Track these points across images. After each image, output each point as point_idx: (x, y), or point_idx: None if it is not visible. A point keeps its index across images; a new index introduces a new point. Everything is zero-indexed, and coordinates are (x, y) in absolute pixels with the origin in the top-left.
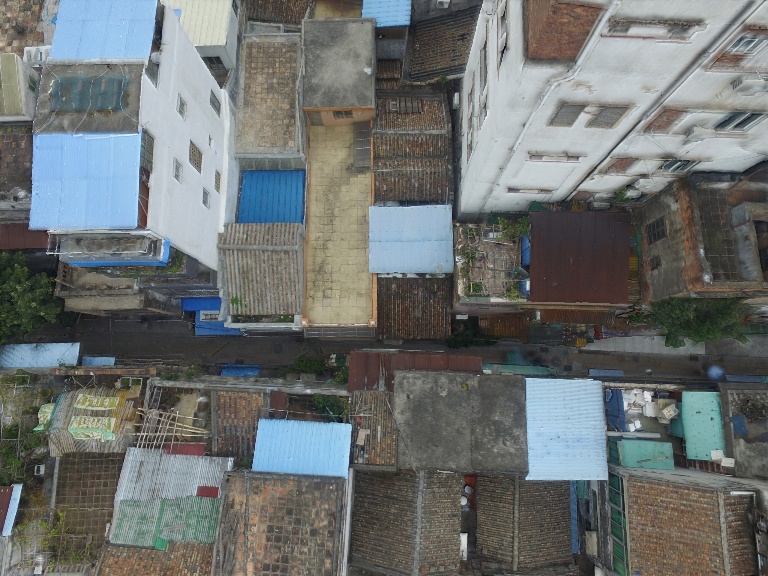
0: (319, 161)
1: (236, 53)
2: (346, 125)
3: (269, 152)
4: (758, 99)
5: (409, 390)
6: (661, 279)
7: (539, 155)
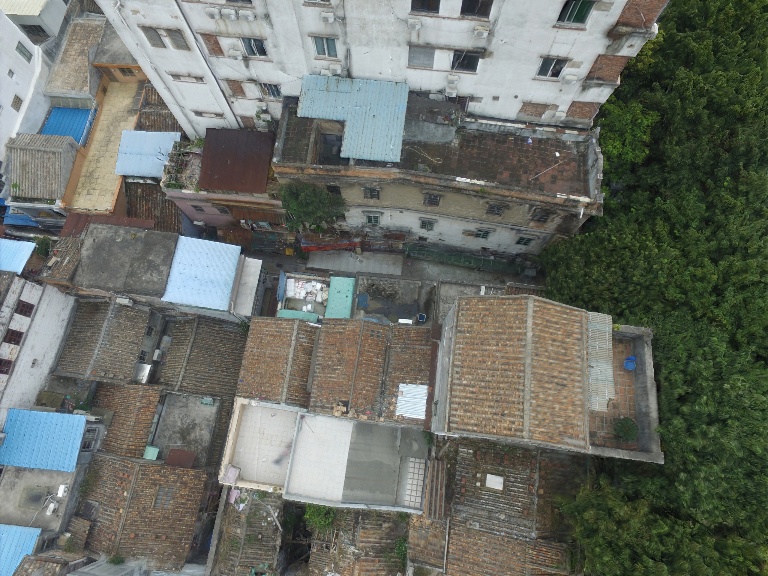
0: (110, 105)
1: (60, 27)
2: (135, 83)
3: (69, 93)
4: (239, 27)
5: (96, 236)
6: None
7: (174, 75)
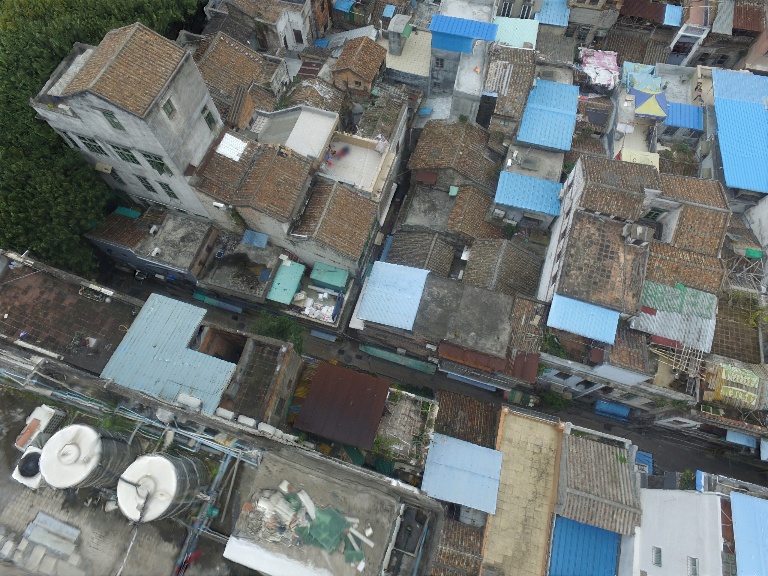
0: None
1: None
2: None
3: None
4: None
5: (497, 343)
6: (293, 370)
7: None
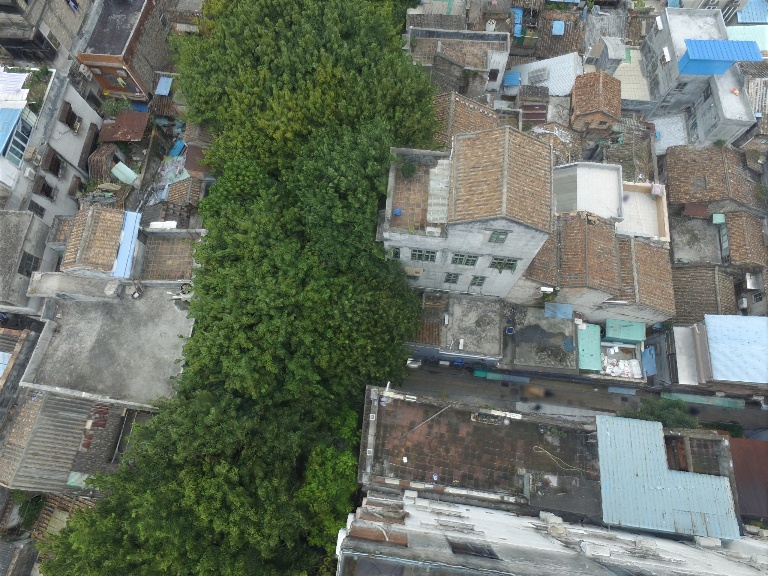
0: None
1: None
2: None
3: None
4: None
5: None
6: None
7: None
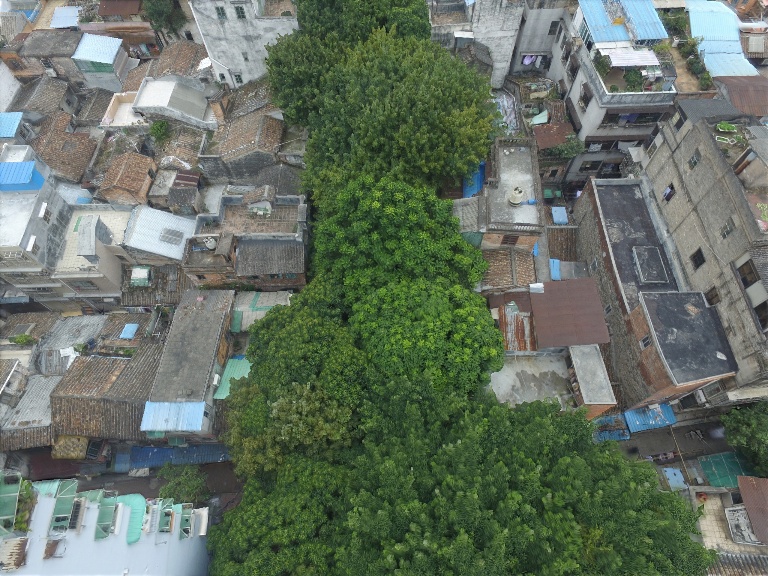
0: (50, 6)
1: None
2: None
3: None
4: None
5: (34, 36)
6: None
7: None
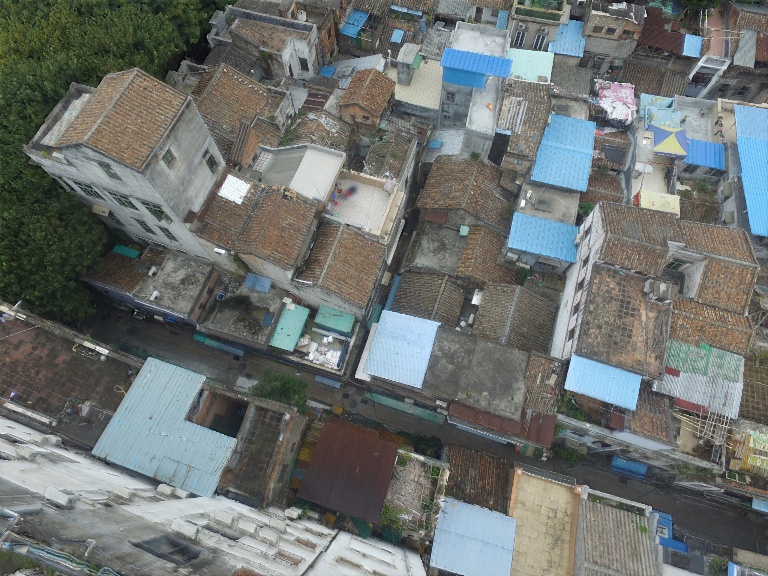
0: None
1: None
2: None
3: None
4: None
5: (511, 403)
6: None
7: None
